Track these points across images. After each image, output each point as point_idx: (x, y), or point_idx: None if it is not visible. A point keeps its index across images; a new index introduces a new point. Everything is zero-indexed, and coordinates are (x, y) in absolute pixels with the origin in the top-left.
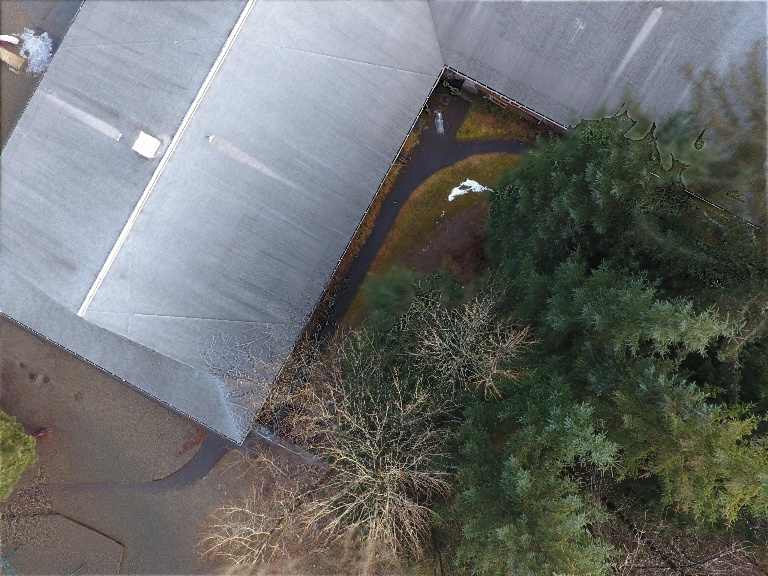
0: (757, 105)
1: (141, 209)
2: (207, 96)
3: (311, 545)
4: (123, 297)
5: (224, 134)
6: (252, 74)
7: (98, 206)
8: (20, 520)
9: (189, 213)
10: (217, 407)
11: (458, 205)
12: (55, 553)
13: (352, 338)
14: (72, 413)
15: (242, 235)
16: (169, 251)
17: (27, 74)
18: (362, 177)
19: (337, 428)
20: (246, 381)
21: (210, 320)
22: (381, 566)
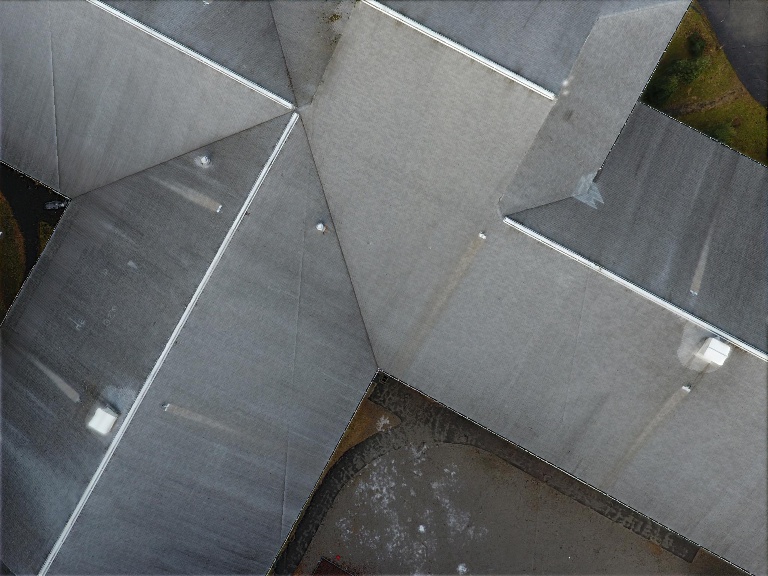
0: None
1: None
2: None
3: None
4: None
5: None
6: None
7: None
8: None
9: None
10: None
11: None
12: None
13: None
14: None
15: None
16: None
17: None
18: None
19: None
20: None
21: None
22: None
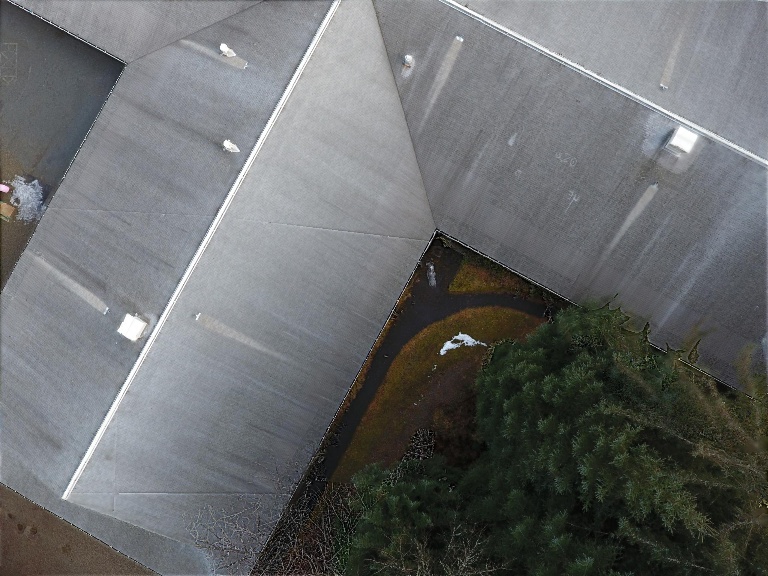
0: (755, 283)
1: (127, 390)
2: (194, 275)
3: None
4: (108, 477)
5: (211, 311)
6: (240, 251)
7: (84, 383)
8: None
9: (175, 391)
10: None
11: (450, 359)
12: None
13: (342, 494)
14: (60, 565)
15: (229, 409)
16: (155, 429)
17: (17, 222)
18: (351, 344)
19: None
20: (233, 552)
21: (196, 494)
22: None
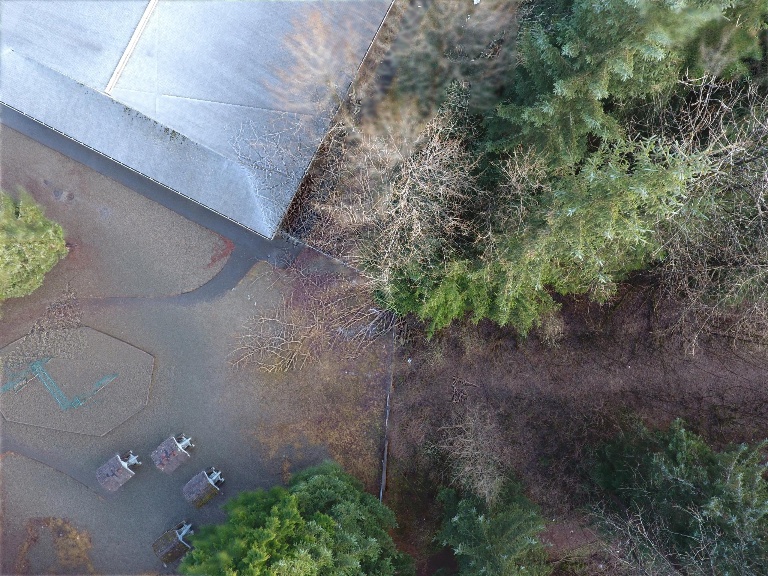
0: None
1: None
2: None
3: (343, 352)
4: (150, 76)
5: None
6: None
7: None
8: (50, 333)
9: None
10: (247, 200)
11: (484, 8)
12: (86, 365)
13: (379, 146)
14: (98, 229)
15: (268, 18)
16: (195, 30)
17: None
18: None
19: (366, 236)
20: (275, 173)
21: (238, 106)
22: (414, 370)
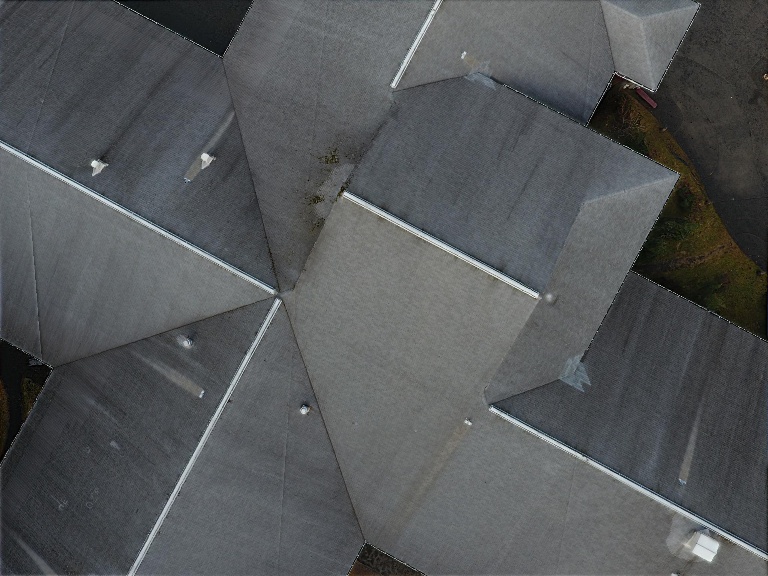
0: None
1: None
2: None
3: None
4: None
5: None
6: (0, 178)
7: None
8: None
9: None
10: None
11: None
12: None
13: None
14: None
15: None
16: None
17: None
18: None
19: None
20: None
21: None
22: None
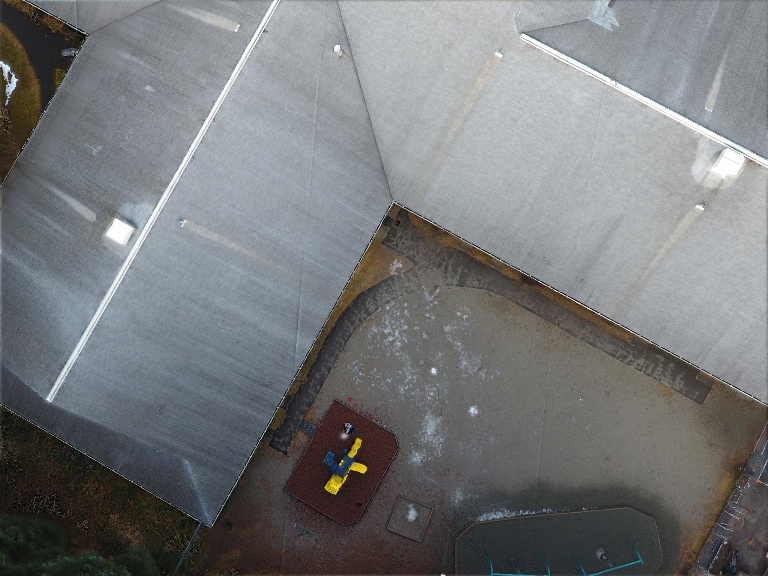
0: (7, 317)
1: None
2: None
3: None
4: None
5: None
6: None
7: None
8: None
9: None
10: None
11: None
12: None
13: None
14: None
15: None
16: None
17: None
18: None
19: None
20: None
21: None
22: None
